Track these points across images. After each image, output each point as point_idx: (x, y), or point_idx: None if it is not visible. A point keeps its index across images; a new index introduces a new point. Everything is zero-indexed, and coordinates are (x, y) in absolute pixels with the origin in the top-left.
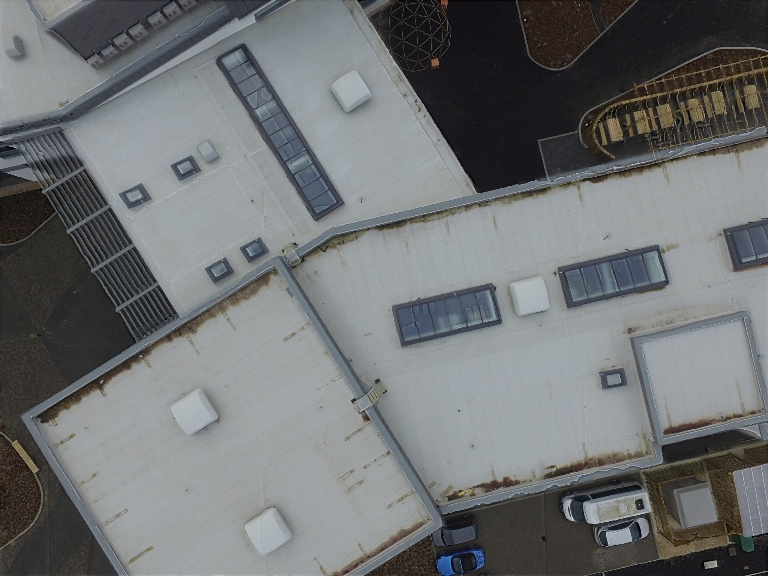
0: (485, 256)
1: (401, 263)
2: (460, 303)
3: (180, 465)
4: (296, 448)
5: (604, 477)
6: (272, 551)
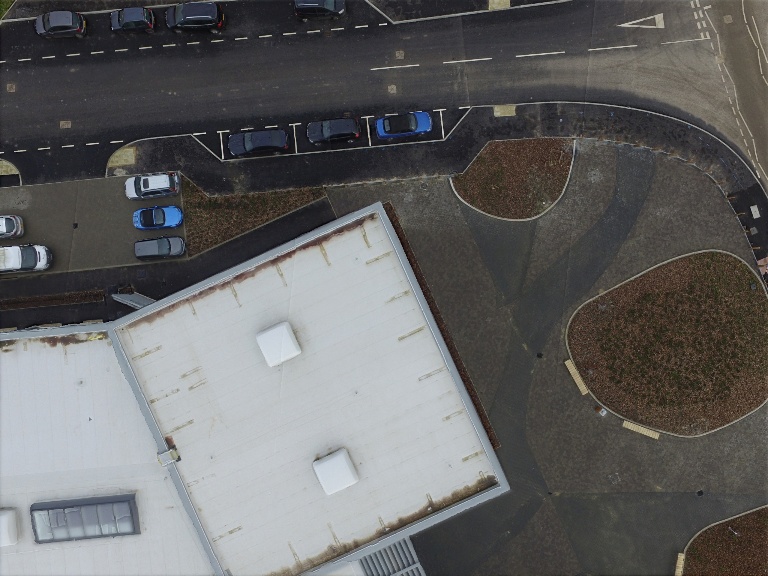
0: (43, 570)
1: (128, 574)
2: (69, 532)
3: (361, 417)
4: (243, 419)
5: (7, 279)
6: (282, 319)
